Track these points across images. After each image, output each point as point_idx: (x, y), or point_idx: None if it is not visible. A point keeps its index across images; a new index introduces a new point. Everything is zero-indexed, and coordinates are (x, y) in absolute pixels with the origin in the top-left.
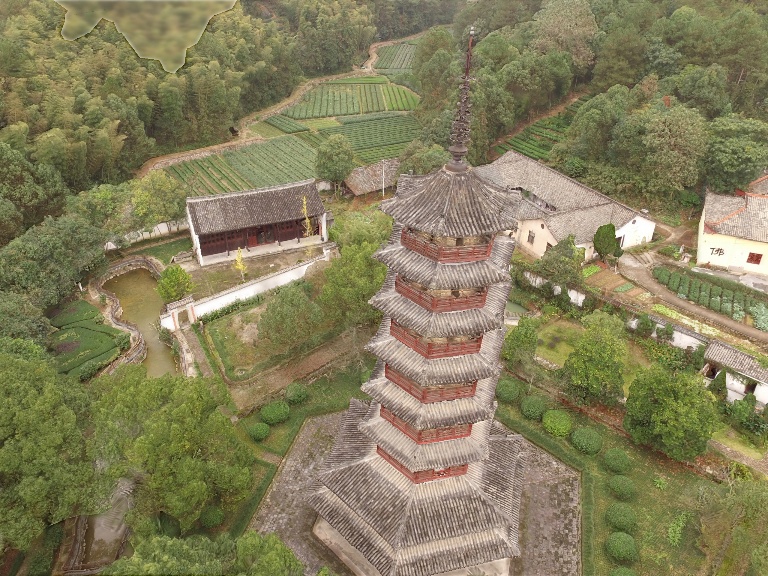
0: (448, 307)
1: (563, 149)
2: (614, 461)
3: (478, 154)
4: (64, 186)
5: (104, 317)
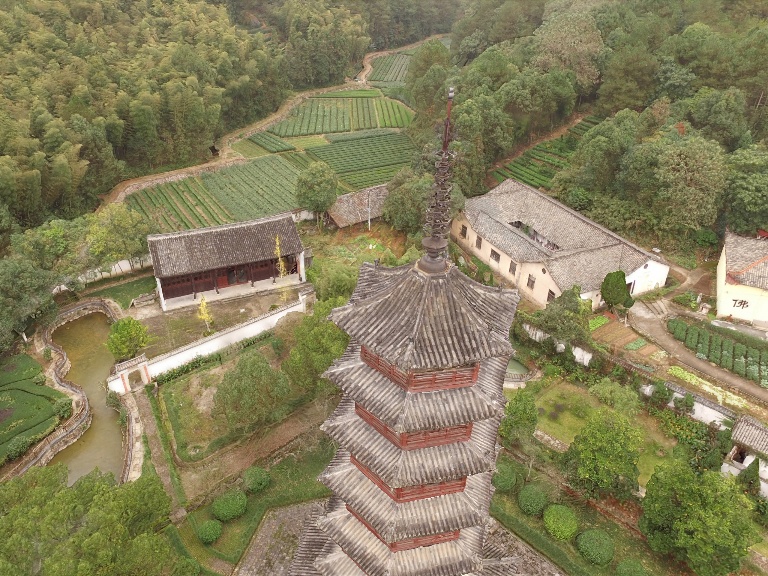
0: (422, 443)
1: (566, 178)
2: None
3: (474, 182)
4: (12, 221)
5: (45, 377)
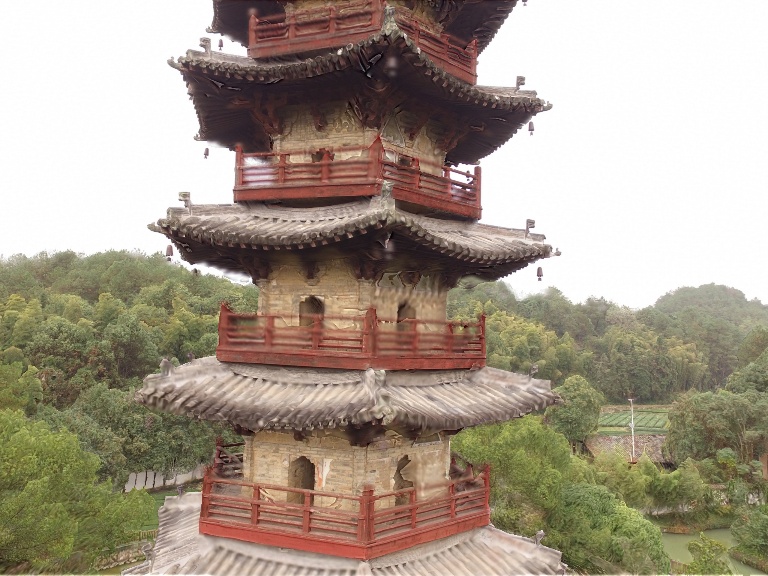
0: (283, 41)
1: None
2: None
3: None
4: None
5: None
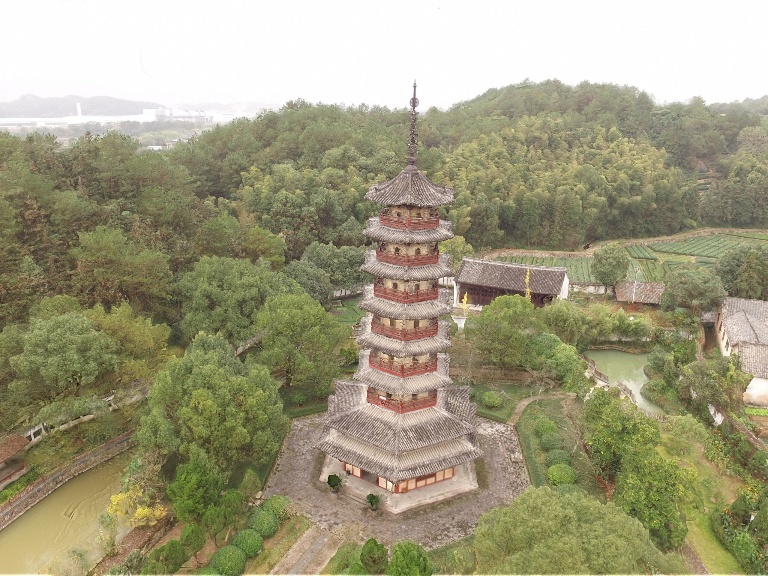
0: (385, 258)
1: None
2: None
3: None
4: None
5: None
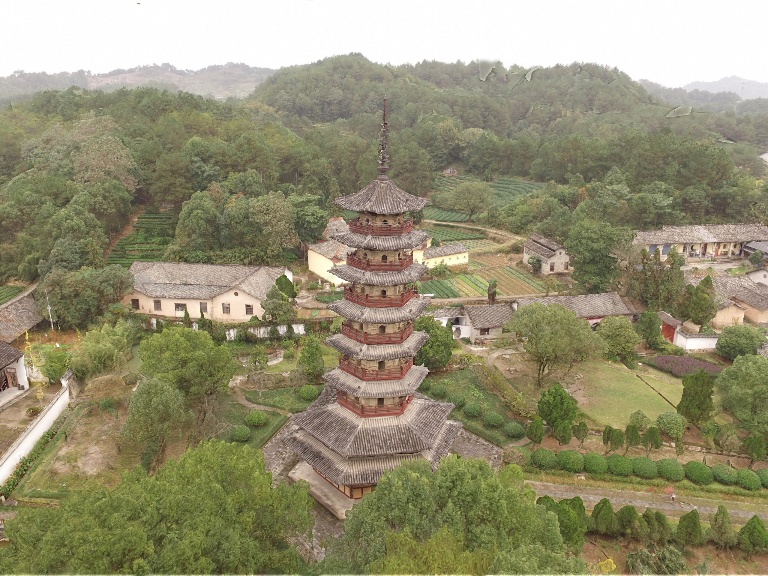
0: None
1: (178, 249)
2: (425, 383)
3: None
4: None
5: None
